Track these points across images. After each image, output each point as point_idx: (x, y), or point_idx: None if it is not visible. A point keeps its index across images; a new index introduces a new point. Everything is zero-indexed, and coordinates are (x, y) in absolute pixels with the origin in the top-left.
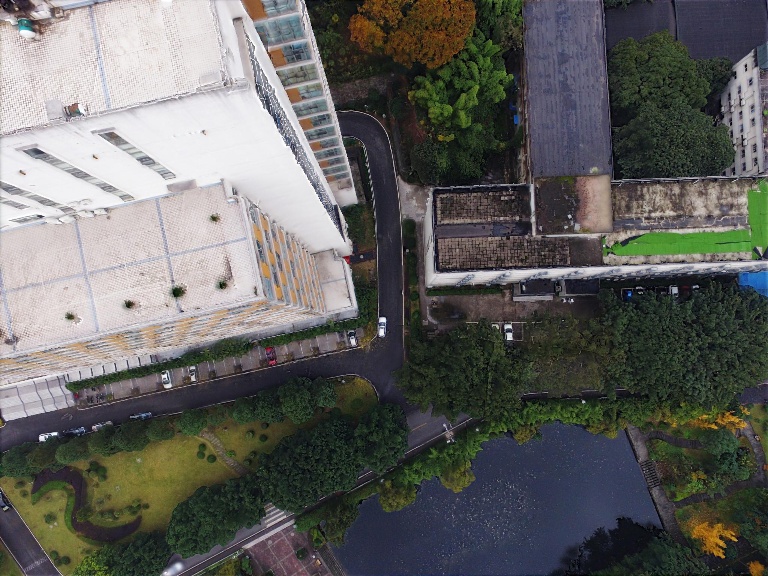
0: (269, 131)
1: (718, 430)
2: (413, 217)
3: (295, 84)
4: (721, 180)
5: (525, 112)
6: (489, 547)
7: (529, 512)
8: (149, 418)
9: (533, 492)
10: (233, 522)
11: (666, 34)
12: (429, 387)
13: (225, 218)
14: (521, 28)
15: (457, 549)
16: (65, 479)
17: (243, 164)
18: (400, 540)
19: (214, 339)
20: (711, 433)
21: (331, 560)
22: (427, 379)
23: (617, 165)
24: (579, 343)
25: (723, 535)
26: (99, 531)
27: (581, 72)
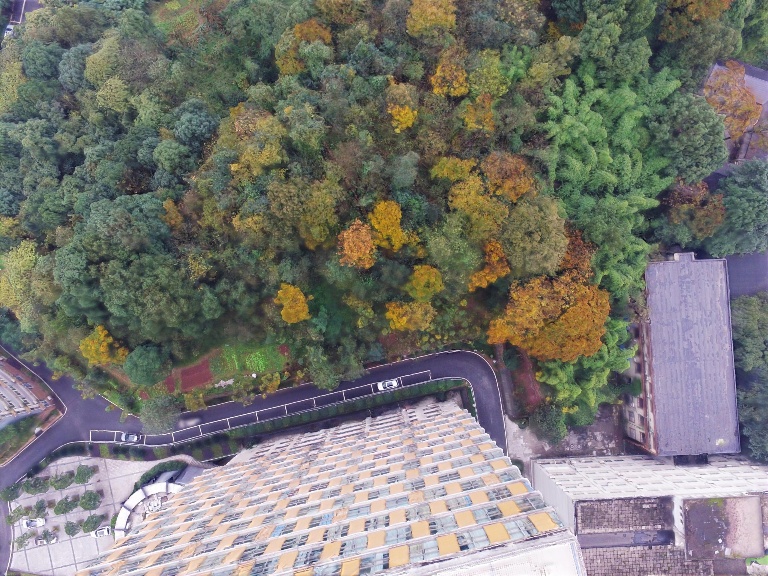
0: None
1: None
2: (521, 457)
3: None
4: None
5: (645, 373)
6: None
7: None
8: None
9: None
10: None
11: None
12: None
13: None
14: (645, 294)
15: None
16: None
17: None
18: None
19: None
20: None
21: None
22: None
23: (743, 436)
24: None
25: None
26: None
27: (706, 339)
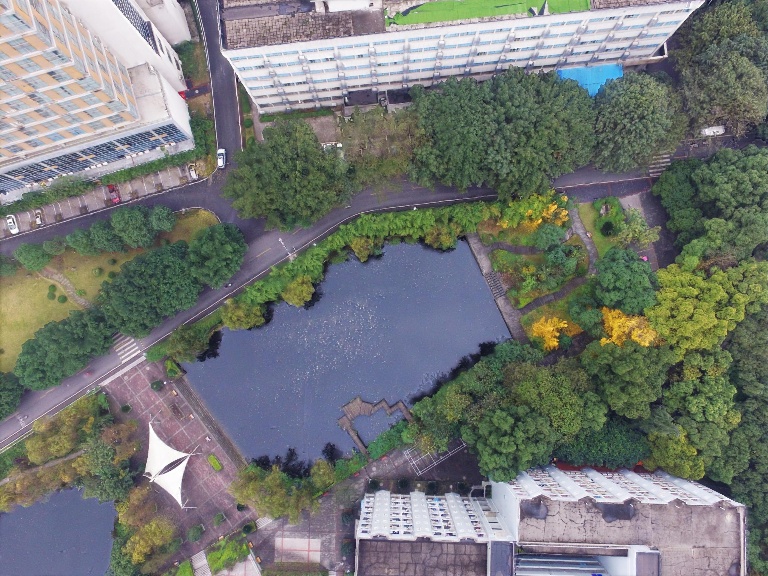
0: None
1: None
2: None
3: None
4: None
5: None
6: (343, 367)
7: (380, 331)
8: None
9: (383, 311)
10: (76, 346)
11: None
12: (249, 190)
13: None
14: None
15: (311, 372)
16: None
17: None
18: (255, 367)
19: (36, 158)
20: (539, 229)
21: (188, 392)
22: (245, 180)
23: None
24: (383, 127)
25: (559, 327)
26: None
27: None
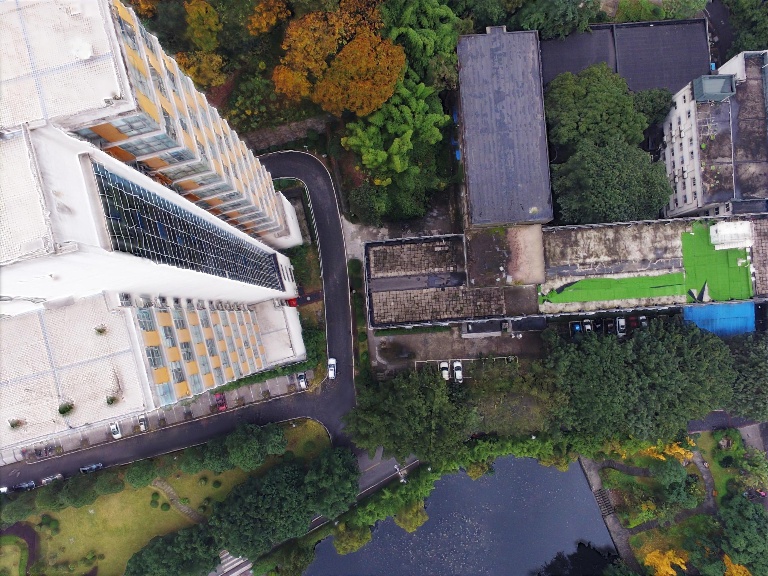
0: (129, 262)
1: (666, 460)
2: (359, 257)
3: (187, 176)
4: (655, 223)
5: (464, 151)
6: None
7: (486, 545)
8: (100, 469)
9: (489, 525)
10: (187, 573)
11: (604, 67)
12: (375, 434)
13: (110, 329)
14: (456, 67)
15: None
16: (17, 534)
17: (119, 280)
18: None
19: None
20: (660, 463)
21: None
22: (372, 427)
23: (556, 204)
24: (521, 387)
25: (674, 562)
26: None
27: (518, 110)
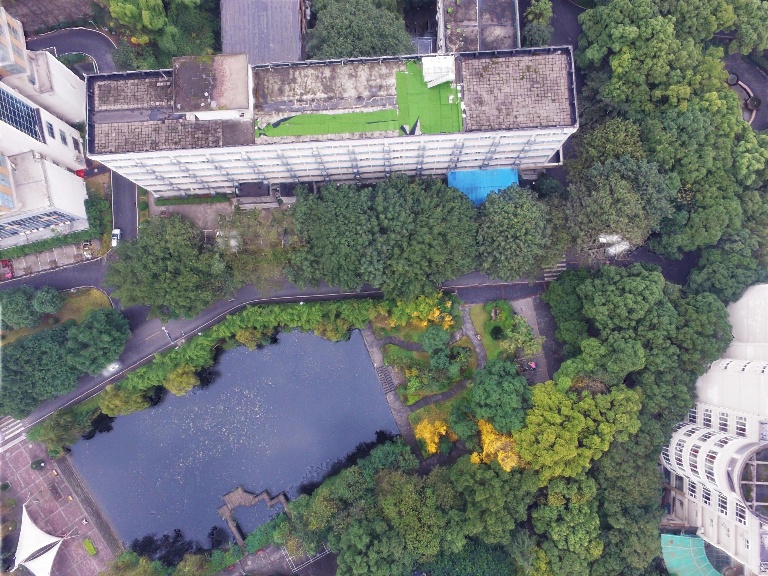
0: None
1: None
2: None
3: None
4: (370, 62)
5: None
6: (227, 455)
7: (266, 420)
8: None
9: (271, 400)
10: None
11: None
12: None
13: None
14: None
15: (195, 458)
16: None
17: None
18: (139, 450)
19: None
20: None
21: (70, 471)
22: (121, 274)
23: None
24: (256, 231)
25: (440, 432)
26: None
27: None
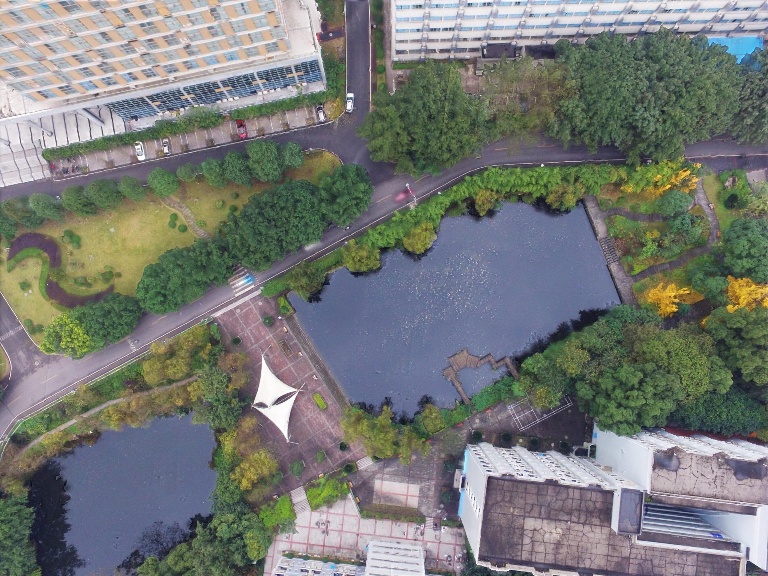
0: None
1: None
2: None
3: None
4: None
5: None
6: (451, 319)
7: (491, 286)
8: None
9: (495, 267)
10: None
11: None
12: (390, 130)
13: None
14: None
15: (420, 321)
16: (40, 246)
17: None
18: (365, 312)
19: (183, 82)
20: (665, 195)
21: (297, 330)
22: (388, 120)
23: None
24: (533, 75)
25: (677, 294)
26: (72, 299)
27: None
